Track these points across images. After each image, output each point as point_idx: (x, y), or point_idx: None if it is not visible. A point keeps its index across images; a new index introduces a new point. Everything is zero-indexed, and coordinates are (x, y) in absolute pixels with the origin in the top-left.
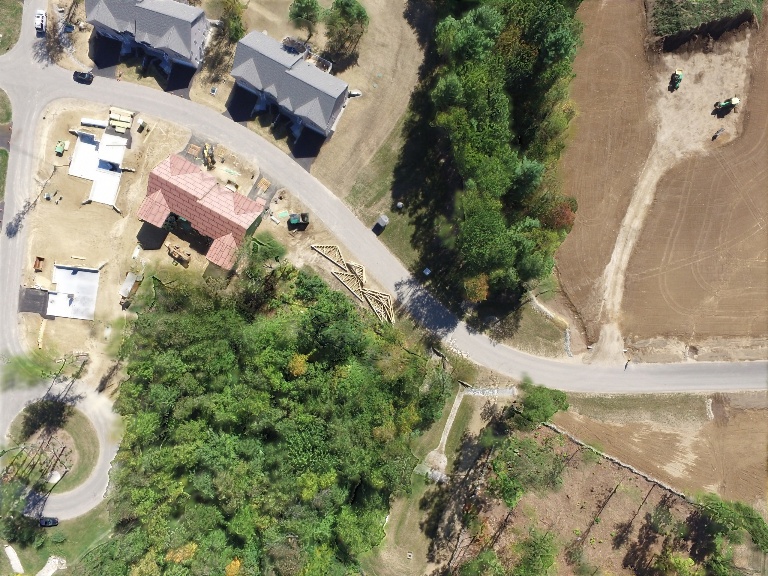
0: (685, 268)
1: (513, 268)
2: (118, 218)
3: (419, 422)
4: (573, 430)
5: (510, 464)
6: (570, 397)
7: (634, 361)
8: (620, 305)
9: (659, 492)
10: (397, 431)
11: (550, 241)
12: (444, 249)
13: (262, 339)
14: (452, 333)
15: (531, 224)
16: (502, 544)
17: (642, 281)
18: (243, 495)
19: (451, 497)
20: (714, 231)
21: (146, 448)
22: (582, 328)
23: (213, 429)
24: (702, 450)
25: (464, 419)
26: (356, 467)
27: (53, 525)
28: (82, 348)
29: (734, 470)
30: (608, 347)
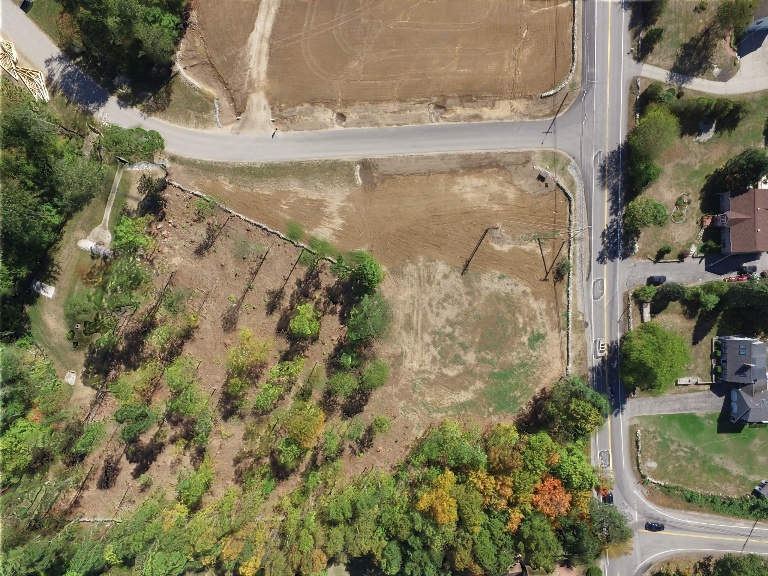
0: (327, 32)
1: (117, 17)
2: None
3: (78, 197)
4: (222, 199)
5: (165, 235)
6: (220, 167)
7: (282, 130)
8: (265, 73)
9: (308, 257)
10: (2, 175)
11: None
12: None
13: None
14: (103, 108)
15: None
16: (163, 313)
17: (286, 48)
18: None
19: (113, 269)
20: None
21: None
22: (231, 99)
23: None
24: (349, 215)
25: (123, 194)
26: None
27: None
28: None
29: (381, 234)
30: (255, 116)
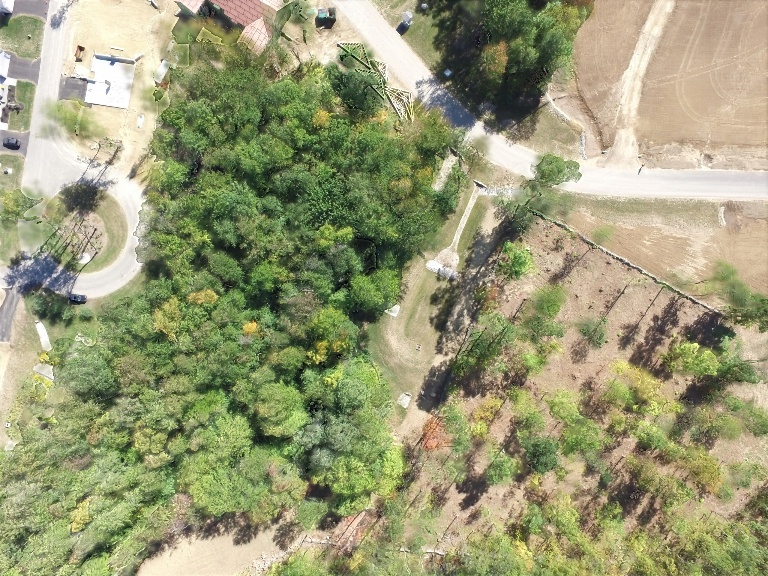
0: (703, 76)
1: (532, 48)
2: (155, 13)
3: (434, 218)
4: (584, 230)
5: None
6: (583, 199)
7: (648, 166)
8: (636, 111)
9: (667, 294)
10: (413, 193)
11: (570, 16)
12: (465, 52)
13: (289, 90)
14: (469, 132)
15: (552, 5)
16: None
17: (659, 87)
18: (263, 249)
19: (461, 292)
20: (734, 40)
21: (175, 195)
22: (598, 133)
23: (238, 181)
24: (712, 255)
25: (477, 218)
26: (372, 223)
27: (82, 302)
28: (116, 136)
29: (744, 277)
30: (623, 151)
